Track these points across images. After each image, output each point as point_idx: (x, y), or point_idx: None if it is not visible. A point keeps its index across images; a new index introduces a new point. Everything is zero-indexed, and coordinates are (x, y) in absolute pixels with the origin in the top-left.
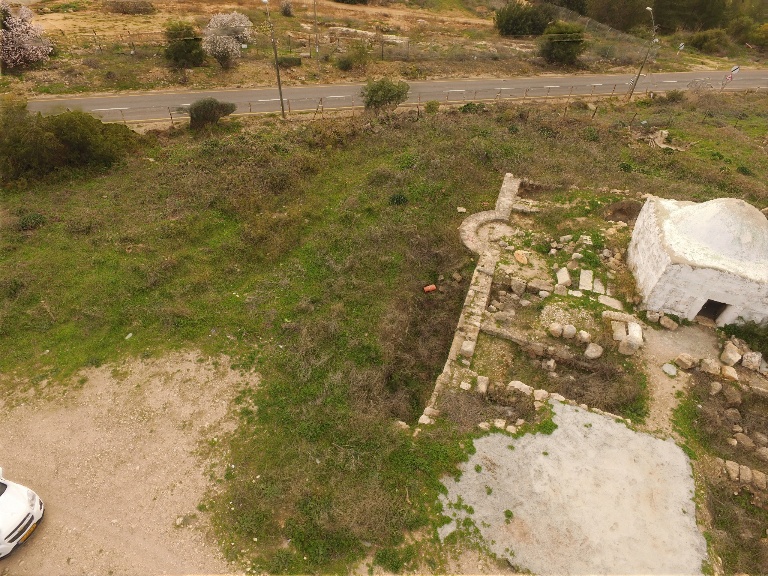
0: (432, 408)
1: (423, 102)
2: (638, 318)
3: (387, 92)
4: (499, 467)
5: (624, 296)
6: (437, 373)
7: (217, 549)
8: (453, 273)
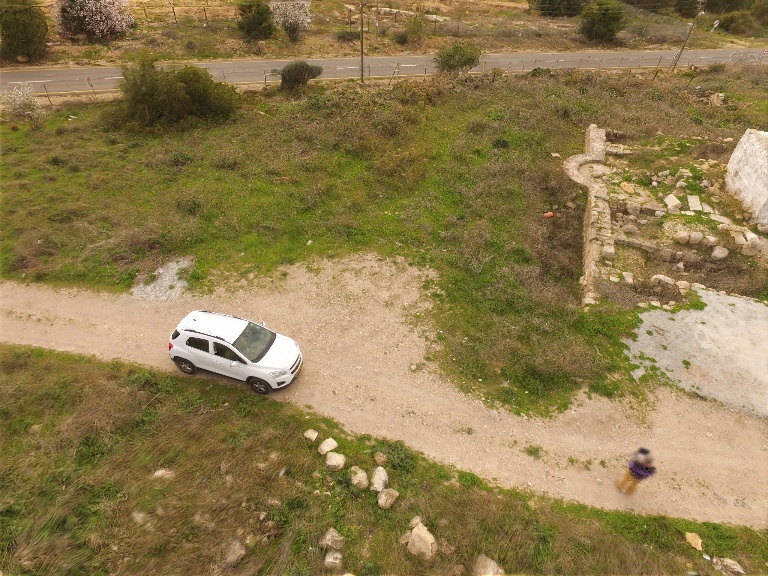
0: (593, 293)
1: (484, 71)
2: (750, 230)
3: None
4: (667, 332)
5: (733, 214)
6: (578, 276)
7: (452, 385)
8: (567, 202)
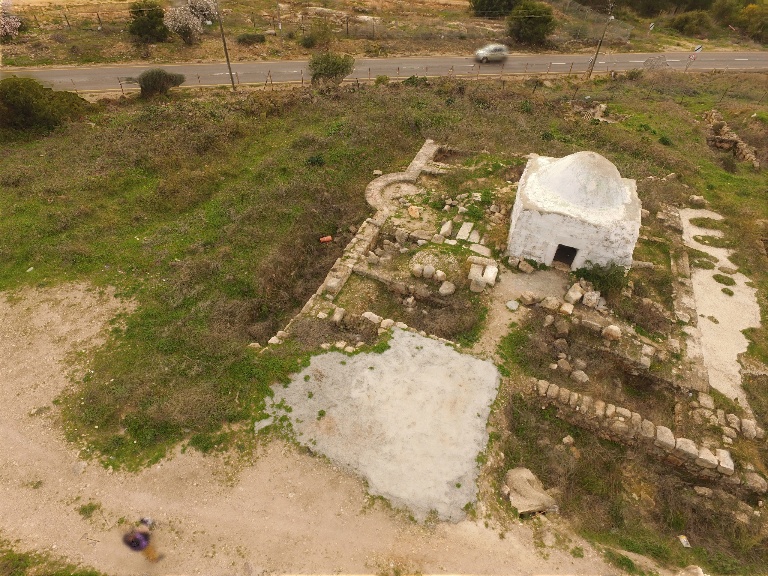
0: (284, 331)
1: None
2: (501, 263)
3: (332, 65)
4: (326, 377)
5: (494, 244)
6: None
7: (61, 433)
8: (350, 226)
